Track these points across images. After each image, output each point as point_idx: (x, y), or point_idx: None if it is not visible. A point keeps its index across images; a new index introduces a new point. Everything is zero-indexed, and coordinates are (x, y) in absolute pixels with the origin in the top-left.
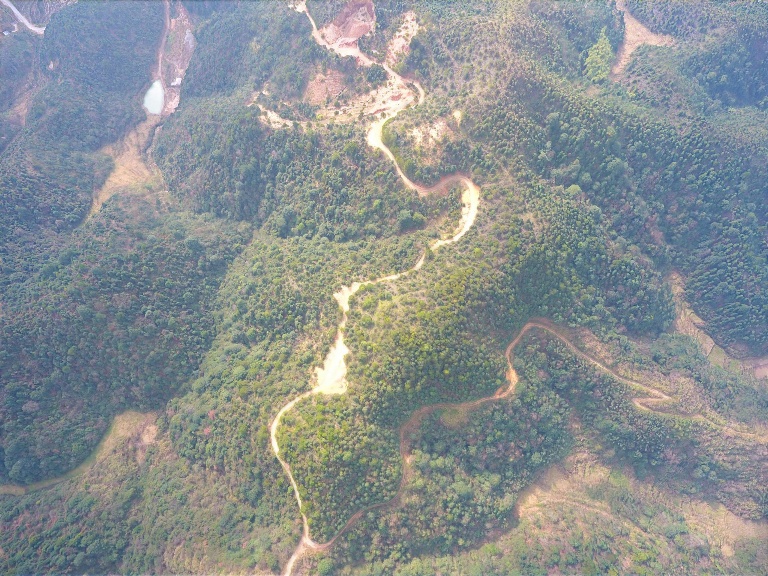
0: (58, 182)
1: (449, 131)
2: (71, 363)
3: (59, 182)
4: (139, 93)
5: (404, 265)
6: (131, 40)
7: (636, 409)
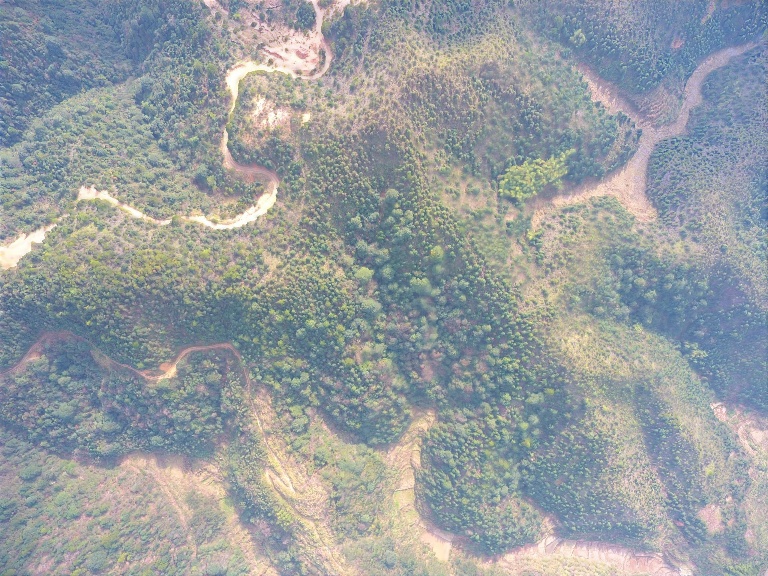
0: None
1: (287, 127)
2: None
3: None
4: None
5: (154, 212)
6: None
7: (260, 476)
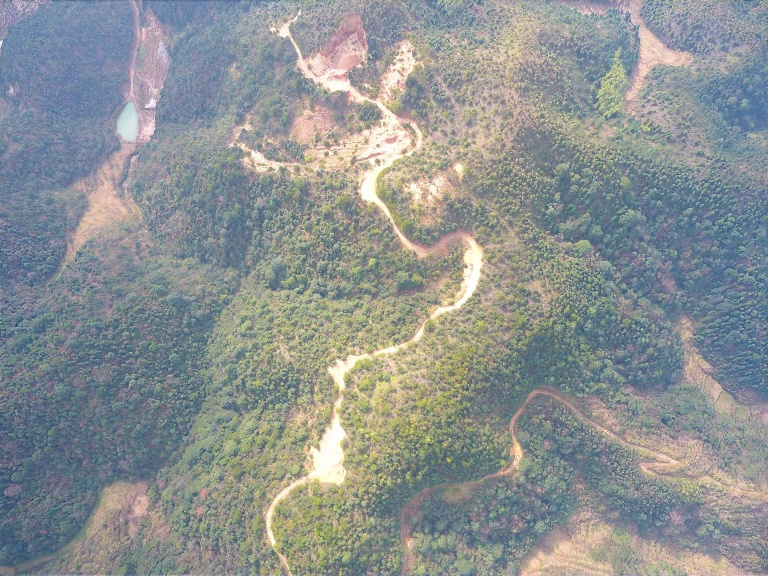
0: (27, 230)
1: (450, 187)
2: (53, 442)
3: (28, 229)
4: (111, 118)
5: (403, 336)
6: (98, 58)
7: (643, 475)
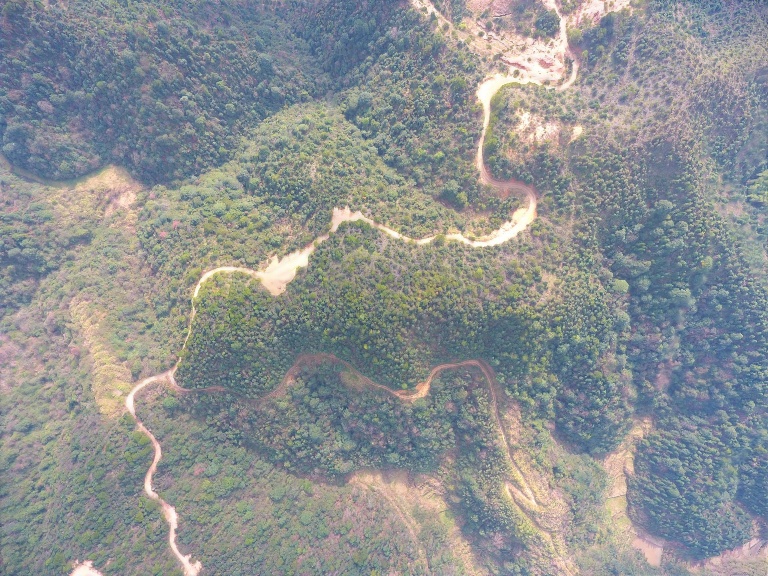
0: None
1: (556, 141)
2: (96, 94)
3: None
4: None
5: (412, 231)
6: None
7: (502, 490)
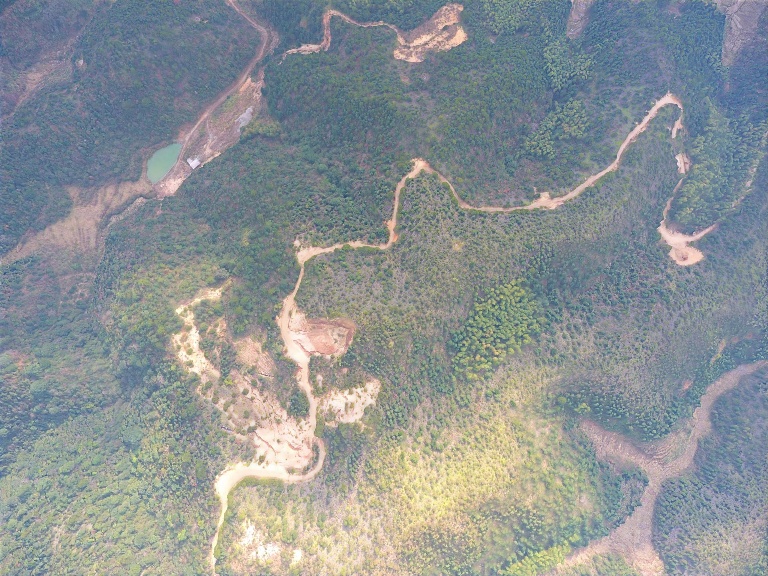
0: None
1: (277, 561)
2: None
3: None
4: (150, 147)
5: None
6: (178, 88)
7: None
